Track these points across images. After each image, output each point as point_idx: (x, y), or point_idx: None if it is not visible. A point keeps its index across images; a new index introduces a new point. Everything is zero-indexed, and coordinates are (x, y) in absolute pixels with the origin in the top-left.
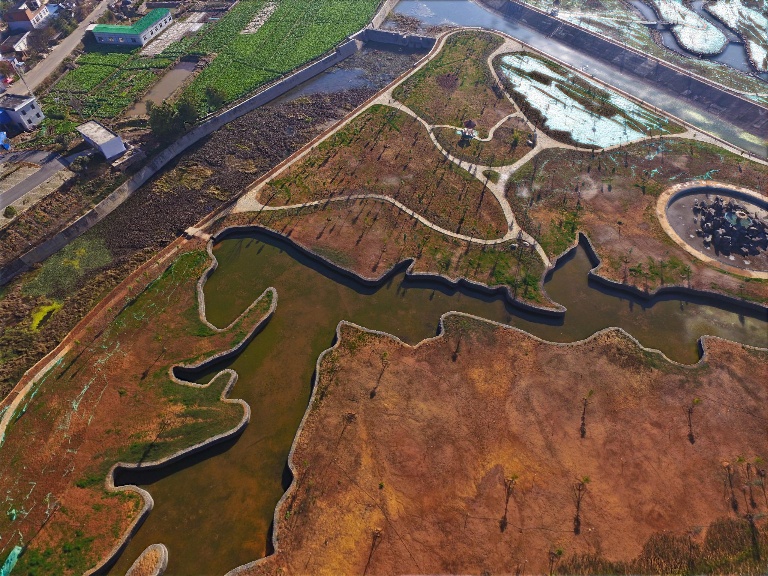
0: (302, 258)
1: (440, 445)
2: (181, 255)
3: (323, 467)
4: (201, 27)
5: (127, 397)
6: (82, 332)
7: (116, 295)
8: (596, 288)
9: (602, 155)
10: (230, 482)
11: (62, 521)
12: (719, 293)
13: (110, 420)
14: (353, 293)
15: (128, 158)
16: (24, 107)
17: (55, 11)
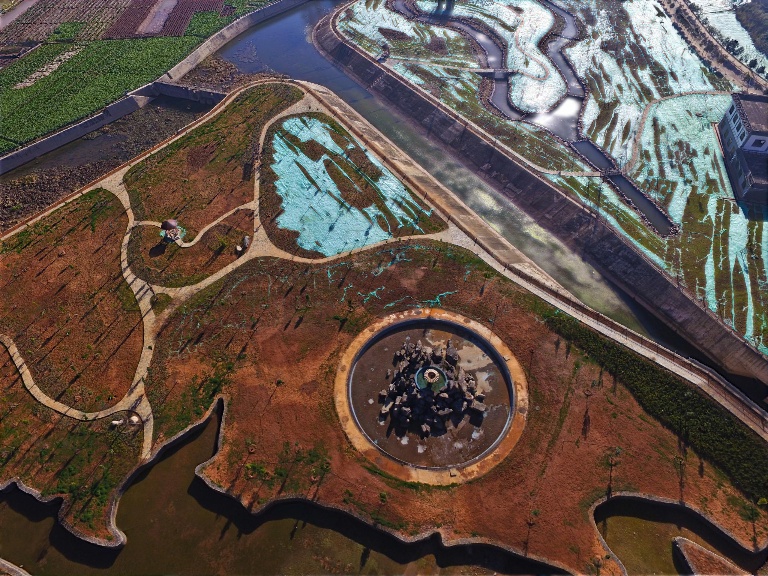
0: None
1: None
2: None
3: None
4: None
5: None
6: None
7: None
8: (195, 495)
9: (318, 268)
10: None
11: None
12: (348, 511)
13: None
14: None
15: None
16: None
17: None
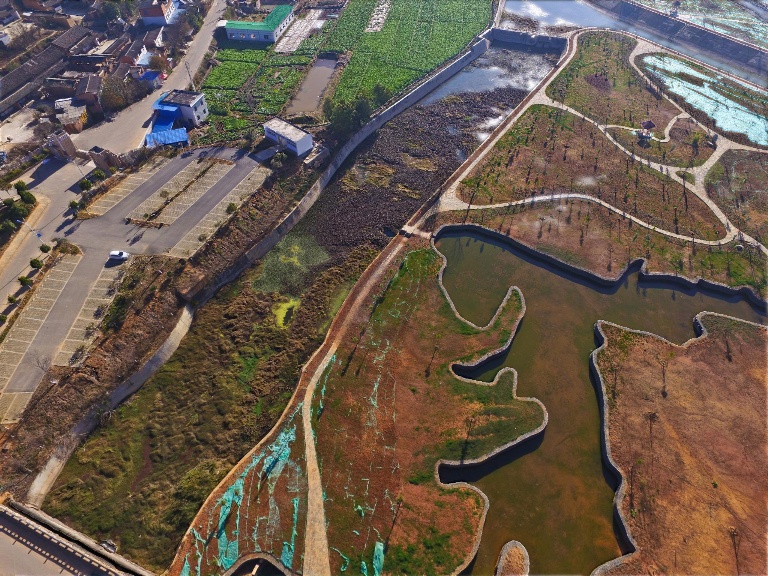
0: None
1: (756, 445)
2: (408, 253)
3: (647, 466)
4: (324, 24)
5: (421, 394)
6: (343, 329)
7: (360, 292)
8: None
9: None
10: (554, 480)
11: (411, 517)
12: None
13: (414, 417)
14: (594, 292)
15: (317, 155)
16: (196, 103)
17: (178, 7)
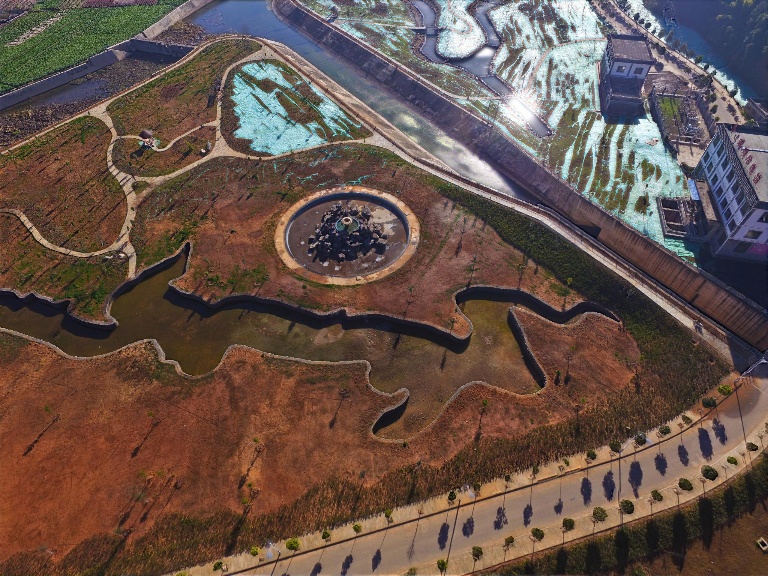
0: None
1: None
2: None
3: None
4: None
5: None
6: None
7: None
8: (169, 299)
9: (267, 163)
10: None
11: None
12: (280, 301)
13: None
14: None
15: None
16: None
17: None
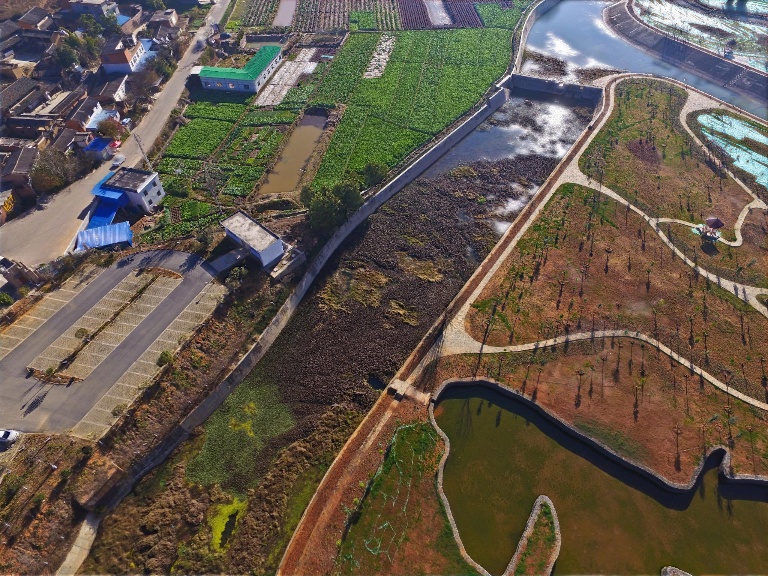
0: (556, 433)
1: None
2: (398, 429)
3: None
4: (316, 68)
5: None
6: (298, 573)
7: (327, 500)
8: None
9: None
10: None
11: None
12: None
13: None
14: (657, 506)
15: (288, 264)
16: (146, 186)
17: (150, 48)
